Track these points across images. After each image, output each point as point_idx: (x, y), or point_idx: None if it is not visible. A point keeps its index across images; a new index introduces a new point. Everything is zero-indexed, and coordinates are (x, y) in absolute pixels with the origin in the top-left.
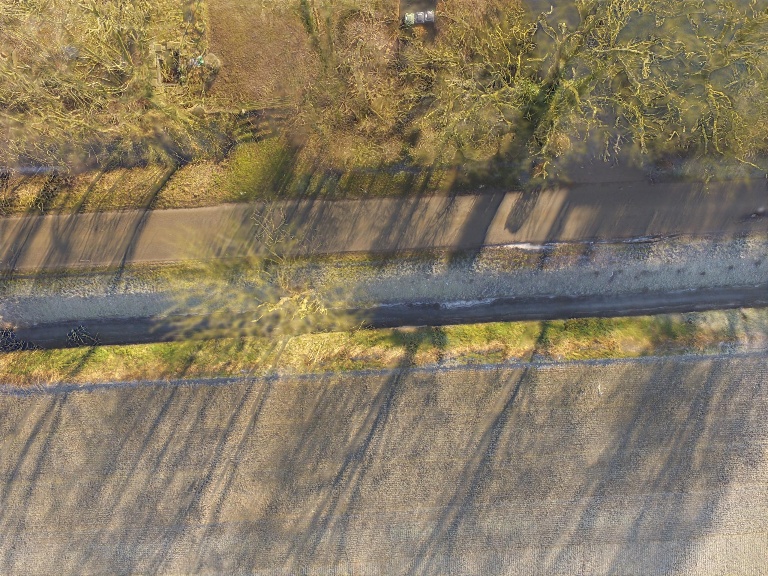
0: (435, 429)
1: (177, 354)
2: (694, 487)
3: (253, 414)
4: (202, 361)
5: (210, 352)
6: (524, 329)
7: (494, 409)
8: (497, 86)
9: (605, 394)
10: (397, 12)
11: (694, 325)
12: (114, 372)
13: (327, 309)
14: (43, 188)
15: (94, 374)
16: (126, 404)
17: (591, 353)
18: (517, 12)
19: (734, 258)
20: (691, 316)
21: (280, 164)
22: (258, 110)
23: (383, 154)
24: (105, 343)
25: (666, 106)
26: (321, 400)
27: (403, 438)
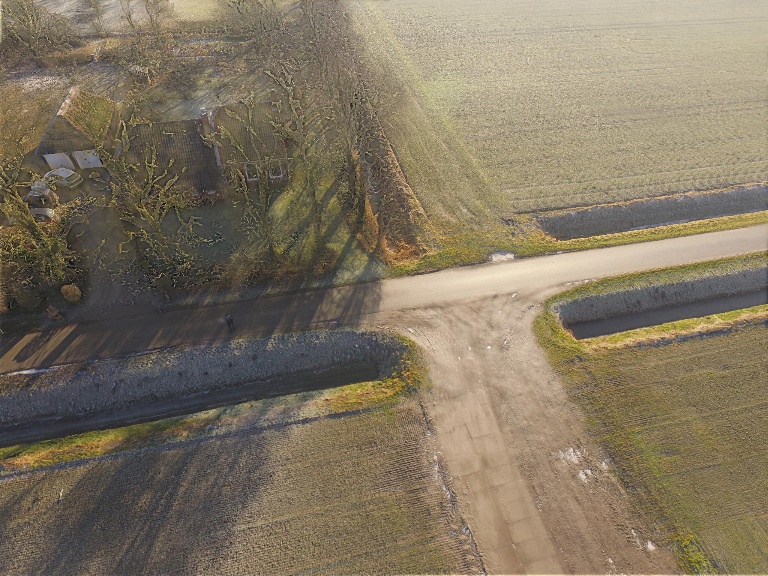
0: None
1: None
2: None
3: None
4: None
5: None
6: None
7: None
8: None
9: (66, 499)
10: None
11: (193, 419)
12: None
13: None
14: None
15: None
16: None
17: (63, 457)
18: None
19: (230, 356)
20: (196, 413)
21: None
22: None
23: None
24: None
25: (175, 266)
26: None
27: None
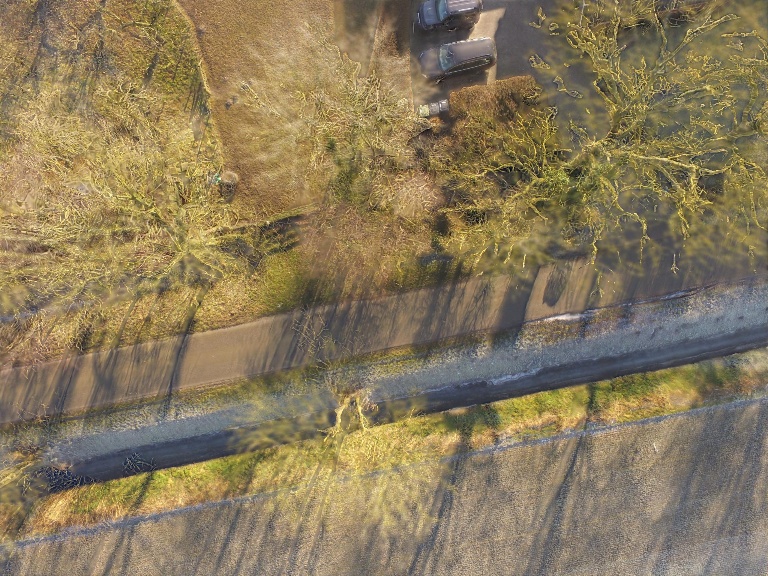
0: (500, 508)
1: (236, 470)
2: (757, 528)
3: (320, 519)
4: (262, 474)
5: (268, 463)
6: (573, 396)
7: (555, 481)
8: (527, 180)
9: (661, 450)
10: (412, 108)
11: (738, 369)
12: (177, 498)
13: (376, 402)
14: (78, 327)
15: (157, 503)
16: (194, 528)
17: (642, 413)
18: (532, 92)
19: None
20: (734, 359)
21: (312, 270)
22: (283, 219)
23: (413, 246)
24: (161, 467)
25: None
26: (385, 496)
27: (470, 521)
